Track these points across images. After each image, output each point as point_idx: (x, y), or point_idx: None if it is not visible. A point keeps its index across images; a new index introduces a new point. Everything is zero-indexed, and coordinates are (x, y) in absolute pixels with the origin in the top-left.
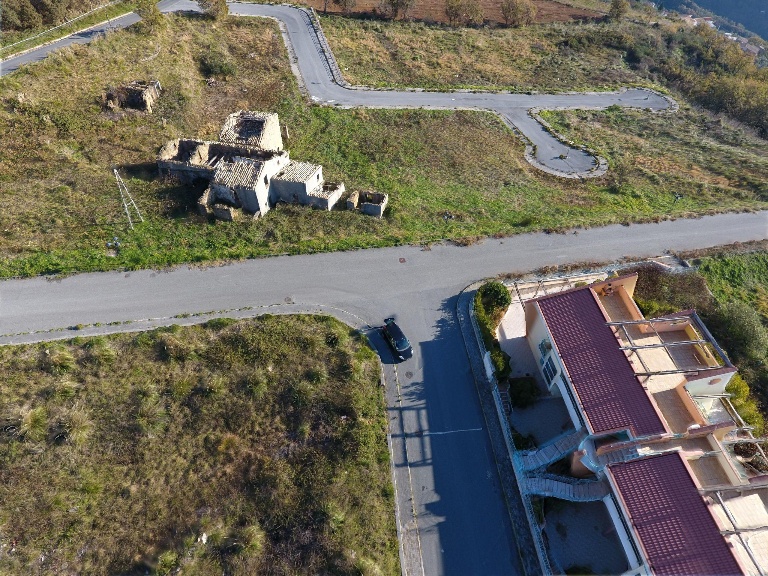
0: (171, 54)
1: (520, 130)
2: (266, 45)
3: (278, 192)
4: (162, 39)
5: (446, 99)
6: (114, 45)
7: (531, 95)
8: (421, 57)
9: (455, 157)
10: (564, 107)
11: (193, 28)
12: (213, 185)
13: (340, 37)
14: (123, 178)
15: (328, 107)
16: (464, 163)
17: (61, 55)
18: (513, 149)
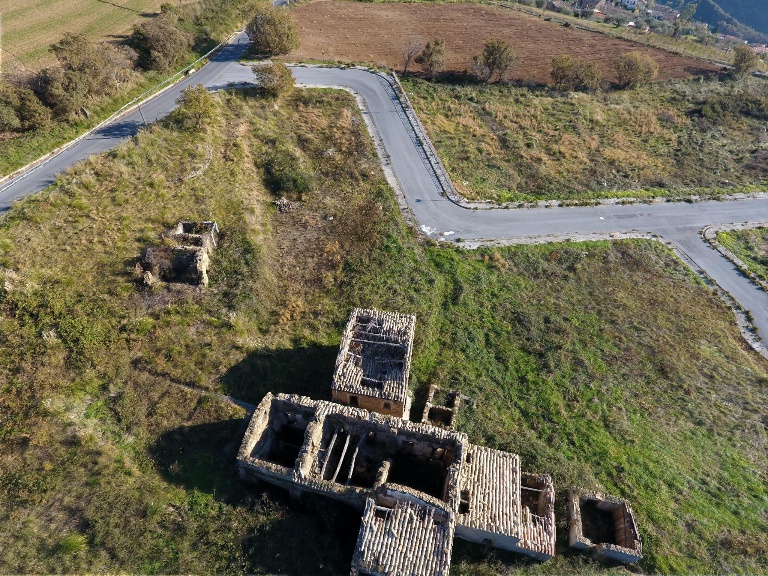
0: (226, 161)
1: (710, 276)
2: (346, 136)
3: (458, 531)
4: (213, 136)
5: (593, 219)
6: (149, 154)
7: (692, 203)
8: (536, 142)
9: (656, 349)
10: (741, 223)
11: (250, 111)
12: (359, 567)
13: (432, 114)
14: (178, 487)
15: (448, 247)
16: (677, 366)
17: (75, 182)
18: (720, 319)
